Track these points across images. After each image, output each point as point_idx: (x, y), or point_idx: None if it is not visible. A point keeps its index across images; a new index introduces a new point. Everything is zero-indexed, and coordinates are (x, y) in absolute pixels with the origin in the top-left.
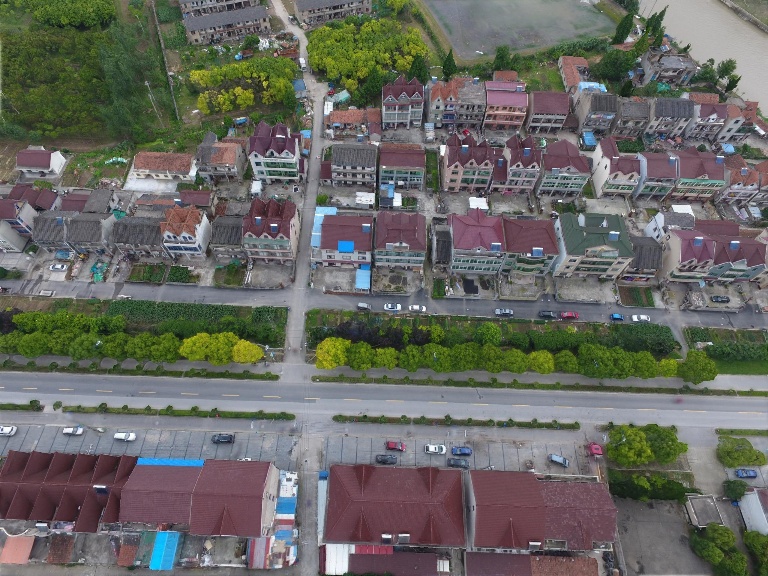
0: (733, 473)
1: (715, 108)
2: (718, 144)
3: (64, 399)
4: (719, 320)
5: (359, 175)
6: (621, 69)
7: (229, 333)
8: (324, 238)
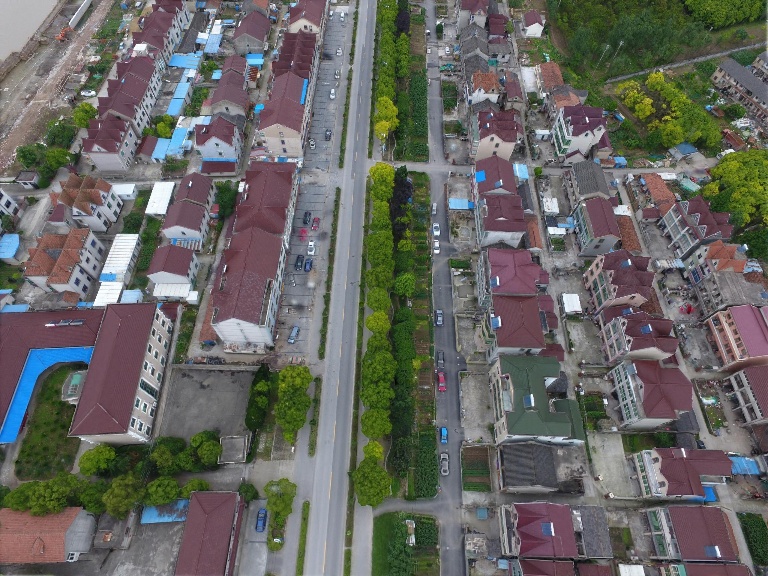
0: (264, 506)
1: None
2: None
3: (357, 69)
4: None
5: None
6: None
7: (396, 119)
8: (485, 161)
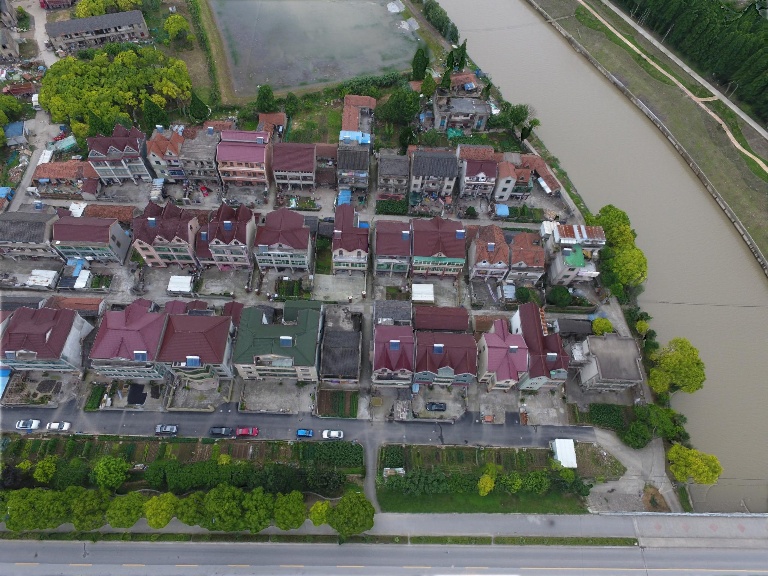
0: None
1: (482, 166)
2: (493, 205)
3: None
4: (428, 434)
5: (38, 249)
6: (405, 113)
7: None
8: None
